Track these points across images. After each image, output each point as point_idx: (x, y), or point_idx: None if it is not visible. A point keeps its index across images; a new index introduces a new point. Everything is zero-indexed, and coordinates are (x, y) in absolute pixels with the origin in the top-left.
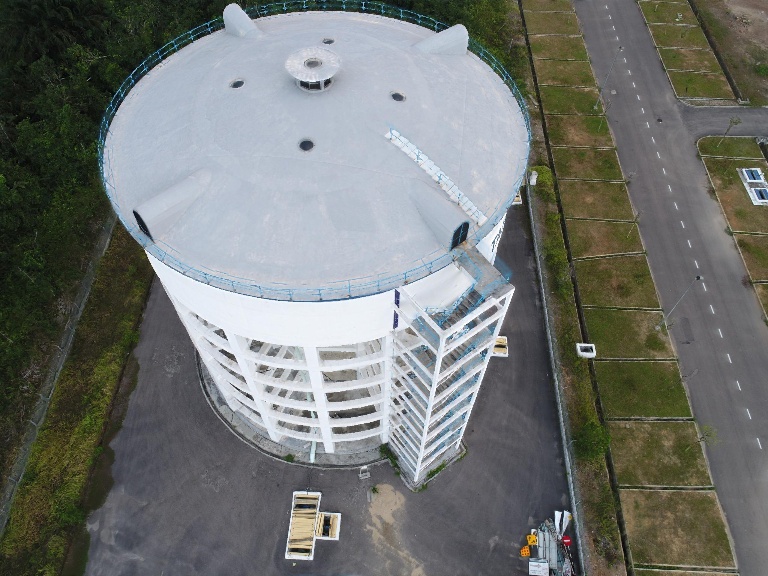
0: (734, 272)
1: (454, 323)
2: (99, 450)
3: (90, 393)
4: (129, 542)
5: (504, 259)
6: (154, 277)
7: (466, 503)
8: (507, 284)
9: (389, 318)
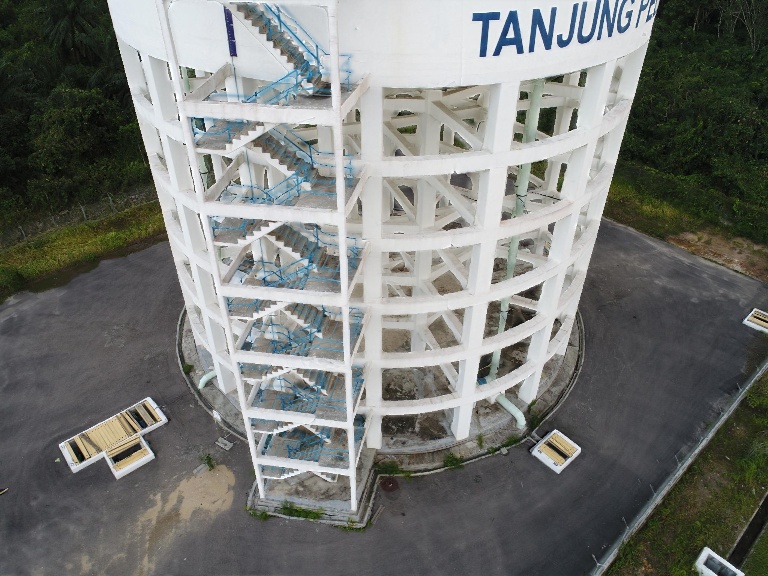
0: None
1: None
2: (89, 256)
3: None
4: (9, 329)
5: (677, 372)
6: None
7: None
8: None
9: (219, 15)
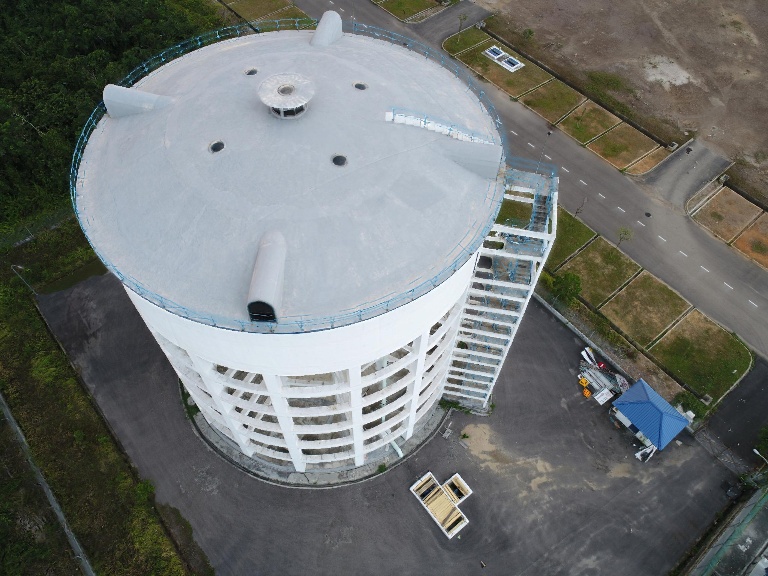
0: (539, 125)
1: (537, 230)
2: None
3: (151, 570)
4: None
5: None
6: (108, 425)
7: (527, 394)
8: (552, 178)
9: (473, 265)
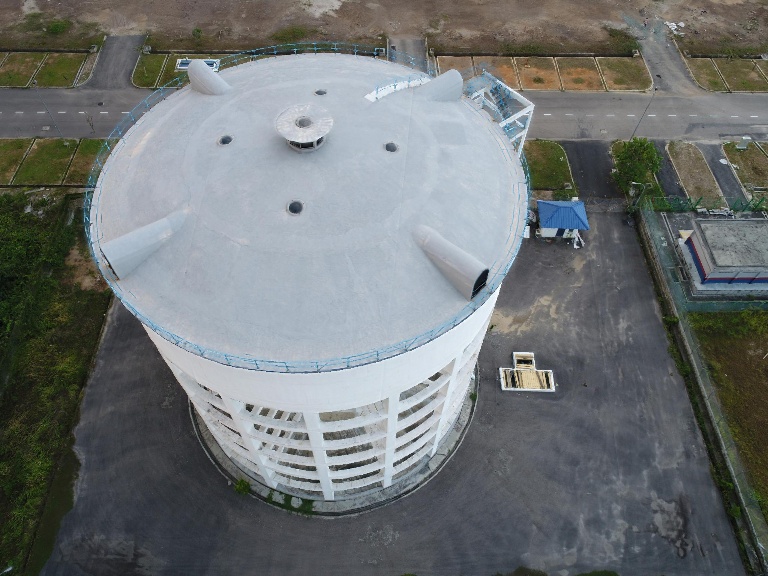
0: None
1: (507, 114)
2: None
3: None
4: (571, 533)
5: None
6: None
7: None
8: (484, 74)
9: None
